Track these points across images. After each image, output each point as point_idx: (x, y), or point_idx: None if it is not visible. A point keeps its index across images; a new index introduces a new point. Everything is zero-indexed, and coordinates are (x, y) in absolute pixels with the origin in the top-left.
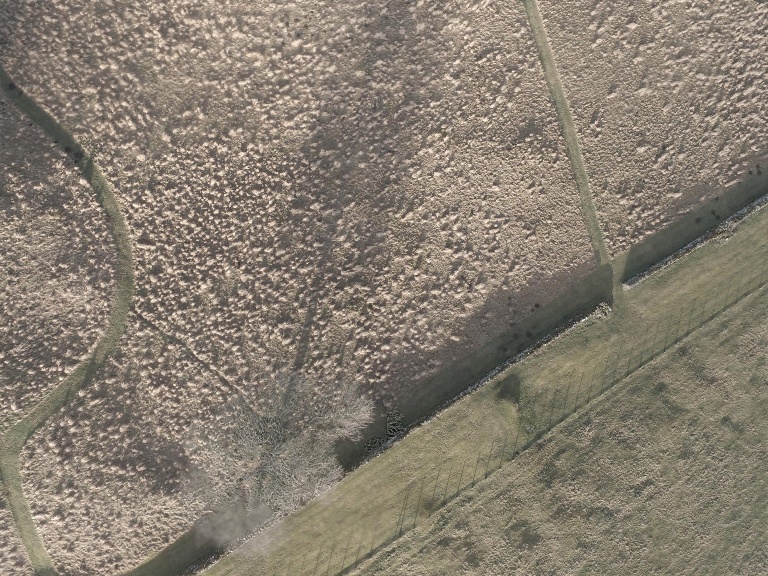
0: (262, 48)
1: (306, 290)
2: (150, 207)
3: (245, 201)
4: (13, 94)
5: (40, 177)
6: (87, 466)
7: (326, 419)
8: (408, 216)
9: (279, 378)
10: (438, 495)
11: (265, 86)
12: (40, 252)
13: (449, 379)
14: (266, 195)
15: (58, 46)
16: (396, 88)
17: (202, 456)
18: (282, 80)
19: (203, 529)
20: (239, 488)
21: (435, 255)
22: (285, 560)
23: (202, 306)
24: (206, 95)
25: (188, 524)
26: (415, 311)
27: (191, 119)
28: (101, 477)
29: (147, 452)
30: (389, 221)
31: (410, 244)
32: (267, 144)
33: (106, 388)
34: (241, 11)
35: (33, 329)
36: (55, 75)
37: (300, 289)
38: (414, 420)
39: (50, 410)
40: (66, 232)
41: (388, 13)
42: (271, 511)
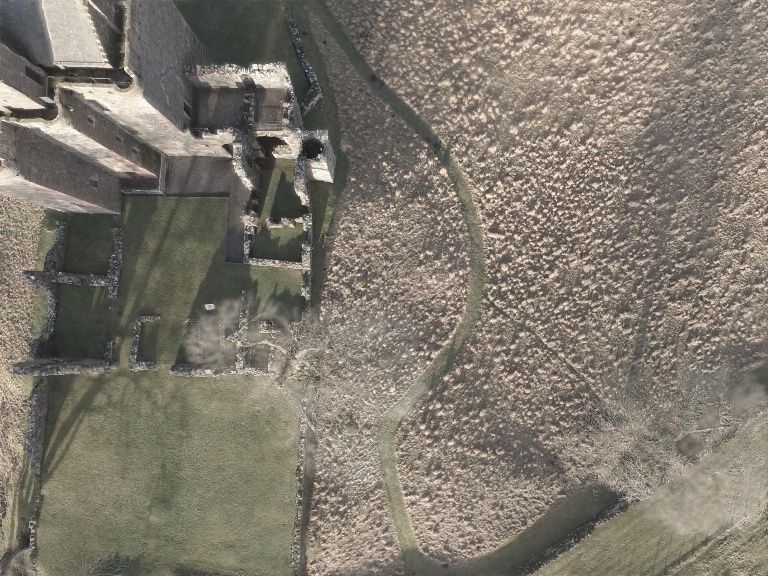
0: (598, 45)
1: (643, 281)
2: (500, 198)
3: (585, 193)
4: (375, 86)
5: (408, 166)
6: (453, 449)
7: (665, 408)
8: (736, 211)
9: (621, 367)
10: (764, 485)
11: (601, 82)
12: (409, 239)
13: None
14: (605, 188)
15: (414, 40)
16: (722, 86)
17: (555, 441)
18: (617, 77)
19: (556, 513)
20: (589, 474)
21: (757, 250)
22: (630, 545)
23: (549, 295)
24: (547, 90)
25: (545, 508)
26: (740, 304)
27: (534, 113)
28: (465, 460)
29: (503, 436)
30: (719, 215)
31: (737, 238)
32: (605, 138)
33: (465, 373)
34: (579, 9)
35: (403, 314)
36: (413, 68)
37: (637, 280)
38: (745, 411)
39: (419, 393)
40: (430, 220)
41: (715, 13)
42: (616, 497)
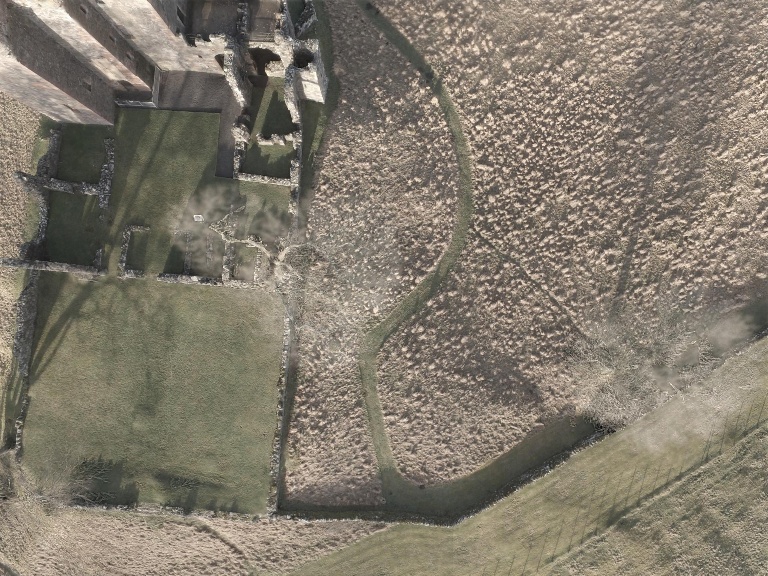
0: None
1: (629, 219)
2: (490, 130)
3: (575, 130)
4: (370, 13)
5: (400, 93)
6: (433, 372)
7: (645, 344)
8: (724, 154)
9: (604, 302)
10: (740, 425)
11: (596, 21)
12: (398, 165)
13: (753, 315)
14: (595, 126)
15: None
16: (716, 30)
17: (534, 371)
18: (611, 16)
19: (533, 441)
20: (567, 404)
21: (744, 194)
22: (604, 476)
23: (535, 228)
24: (541, 26)
25: (522, 435)
26: (725, 247)
27: (528, 48)
28: (445, 384)
29: (484, 364)
30: (707, 158)
31: (724, 182)
32: (597, 77)
33: (448, 300)
34: None
35: (389, 238)
36: None
37: (623, 218)
38: (724, 351)
39: (402, 317)
40: (419, 148)
41: None
42: (593, 429)
